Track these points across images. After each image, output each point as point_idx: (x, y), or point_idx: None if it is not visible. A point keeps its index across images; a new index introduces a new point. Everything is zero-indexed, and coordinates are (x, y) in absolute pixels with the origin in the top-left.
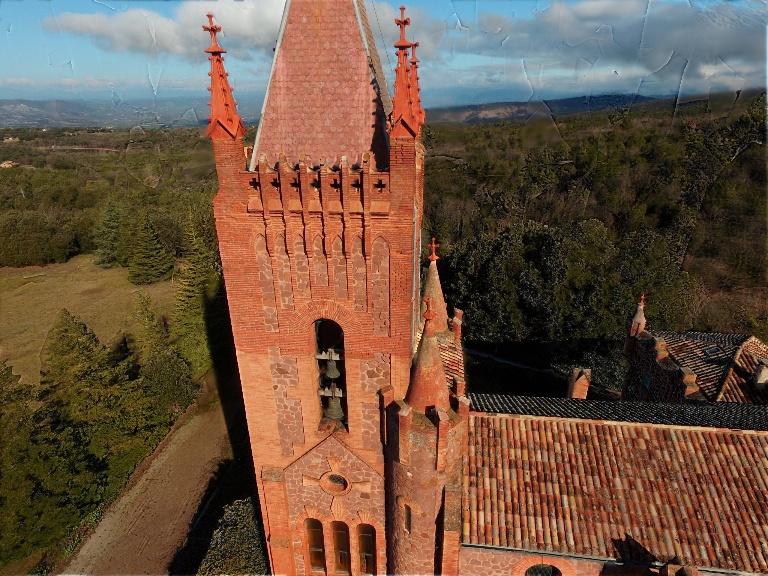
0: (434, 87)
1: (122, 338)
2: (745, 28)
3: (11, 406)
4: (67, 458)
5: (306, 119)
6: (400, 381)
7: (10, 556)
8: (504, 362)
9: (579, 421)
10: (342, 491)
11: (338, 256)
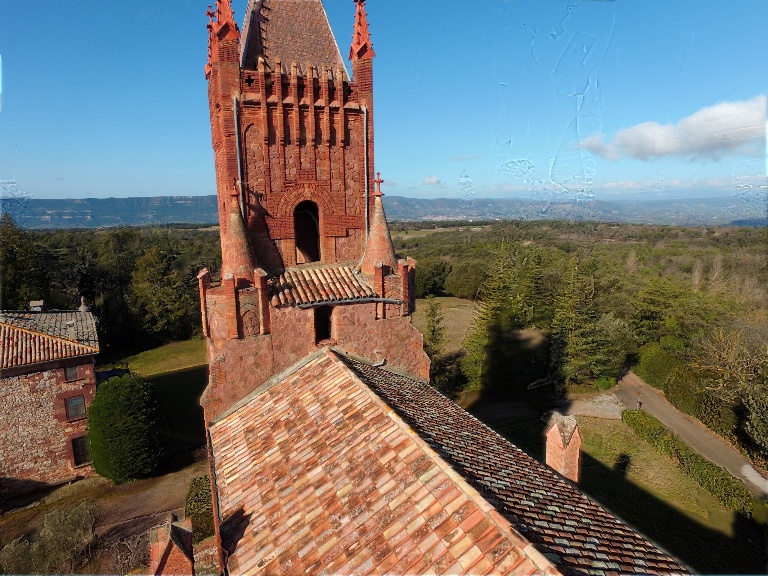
0: None
1: (458, 352)
2: None
3: None
4: None
5: None
6: None
7: None
8: None
9: (374, 398)
10: None
11: None
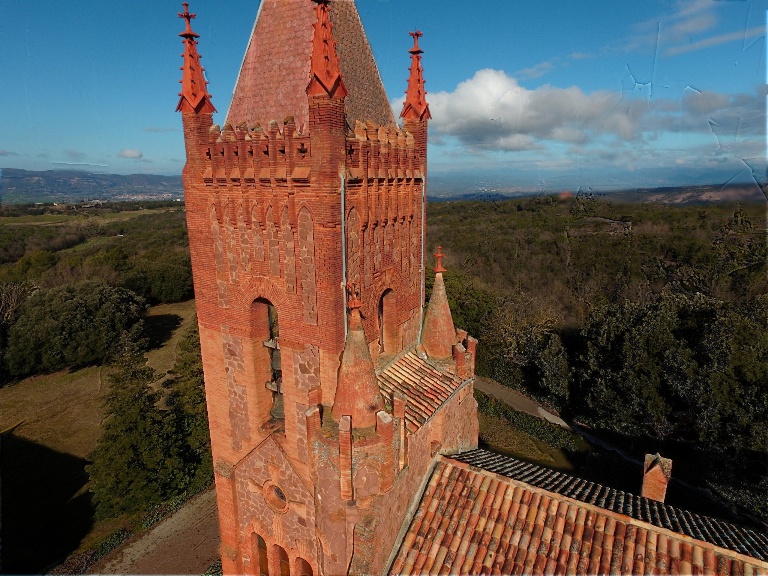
0: (600, 147)
1: None
2: None
3: (134, 382)
4: (166, 441)
5: (264, 95)
6: (329, 382)
7: (104, 512)
8: (633, 461)
9: (592, 508)
10: (282, 508)
11: (272, 228)
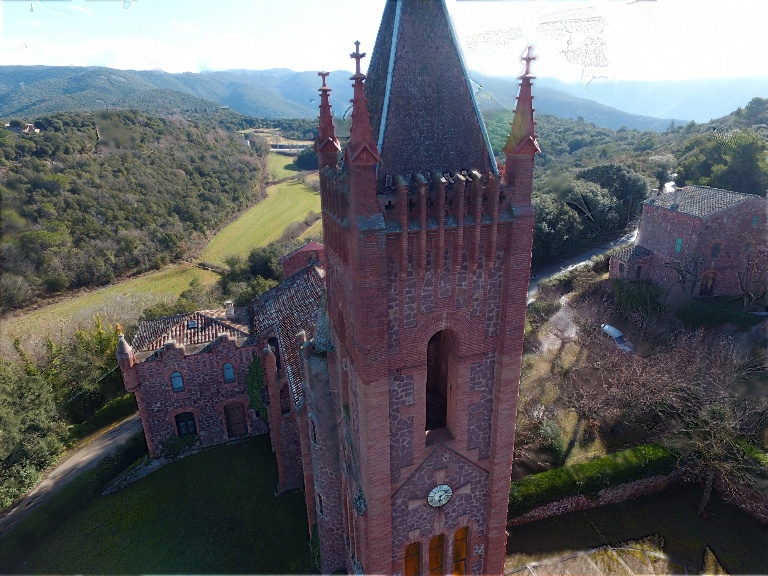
0: None
1: None
2: (489, 104)
3: None
4: None
5: None
6: None
7: None
8: None
9: None
10: None
11: None
